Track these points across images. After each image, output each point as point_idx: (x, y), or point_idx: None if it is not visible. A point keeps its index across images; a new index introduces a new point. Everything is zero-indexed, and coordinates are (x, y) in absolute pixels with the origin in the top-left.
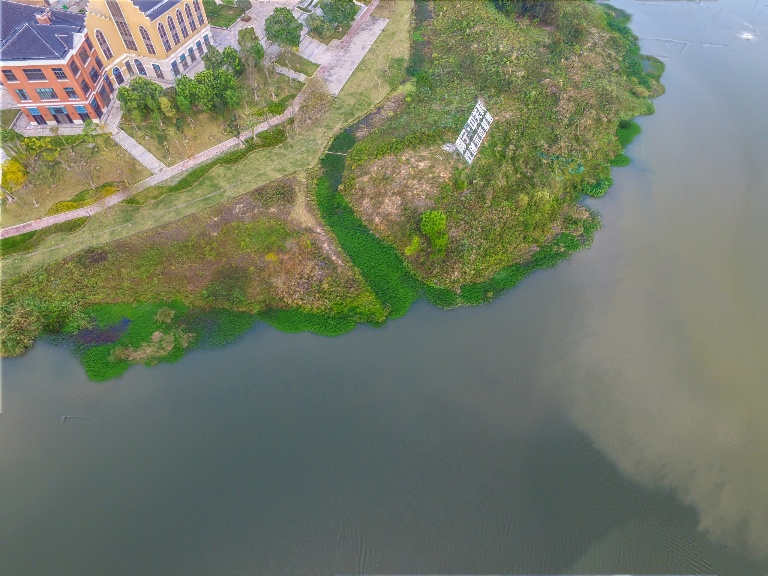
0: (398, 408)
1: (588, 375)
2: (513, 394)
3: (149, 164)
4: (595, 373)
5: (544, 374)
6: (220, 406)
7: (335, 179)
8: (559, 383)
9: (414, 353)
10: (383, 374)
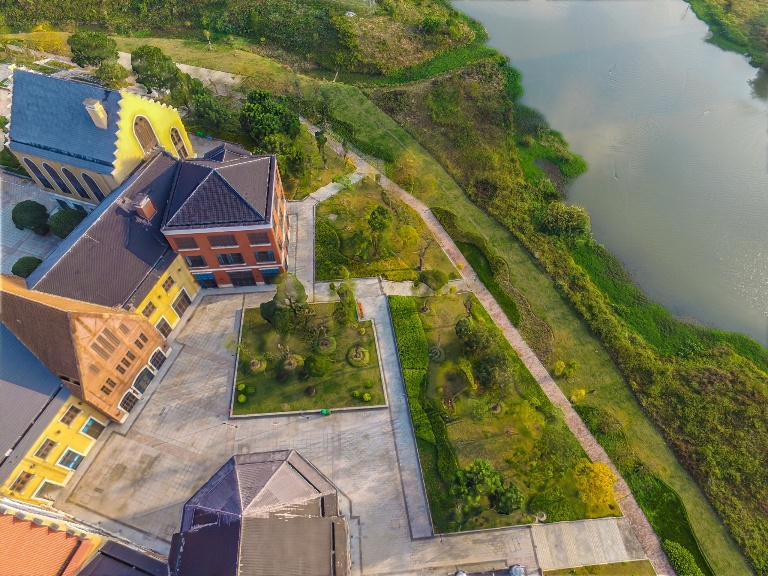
0: (558, 54)
1: (520, 3)
2: (536, 24)
3: (353, 180)
4: (518, 1)
5: (523, 13)
6: (580, 115)
7: (370, 77)
8: (526, 11)
9: (523, 48)
10: (540, 58)
